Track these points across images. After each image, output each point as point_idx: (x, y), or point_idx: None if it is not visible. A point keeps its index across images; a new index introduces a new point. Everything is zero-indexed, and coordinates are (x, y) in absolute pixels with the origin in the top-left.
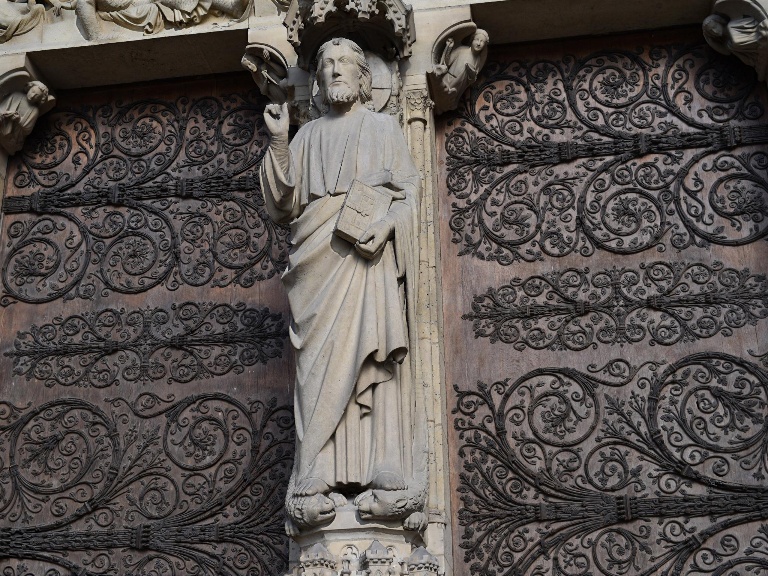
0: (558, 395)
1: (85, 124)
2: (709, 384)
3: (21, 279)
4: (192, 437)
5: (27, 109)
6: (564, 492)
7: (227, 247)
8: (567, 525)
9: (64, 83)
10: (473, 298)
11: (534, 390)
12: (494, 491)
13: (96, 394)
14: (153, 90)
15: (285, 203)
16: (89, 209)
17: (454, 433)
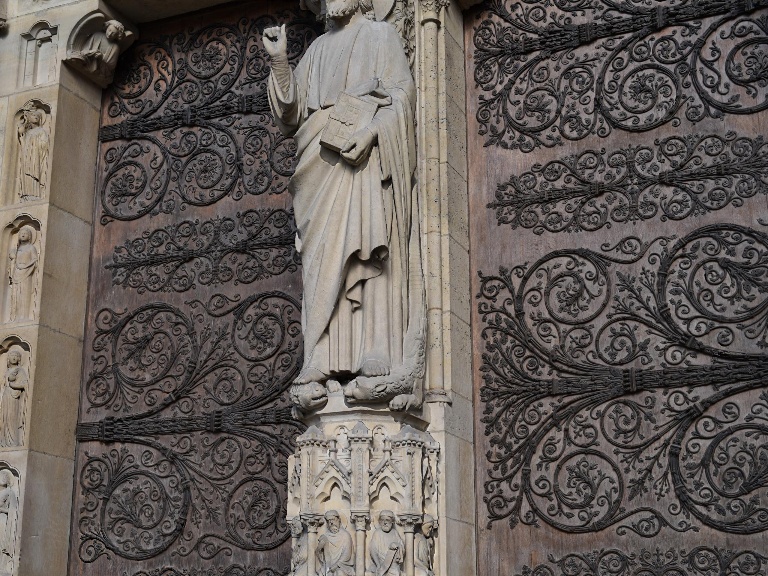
0: (572, 275)
1: (164, 53)
2: (717, 256)
3: (116, 200)
4: (254, 332)
5: (108, 46)
6: (575, 367)
7: (282, 156)
8: (577, 398)
9: (142, 17)
10: (497, 187)
11: (551, 272)
12: (512, 369)
13: (178, 298)
14: (218, 14)
15: (289, 118)
16: (168, 131)
17: (478, 317)
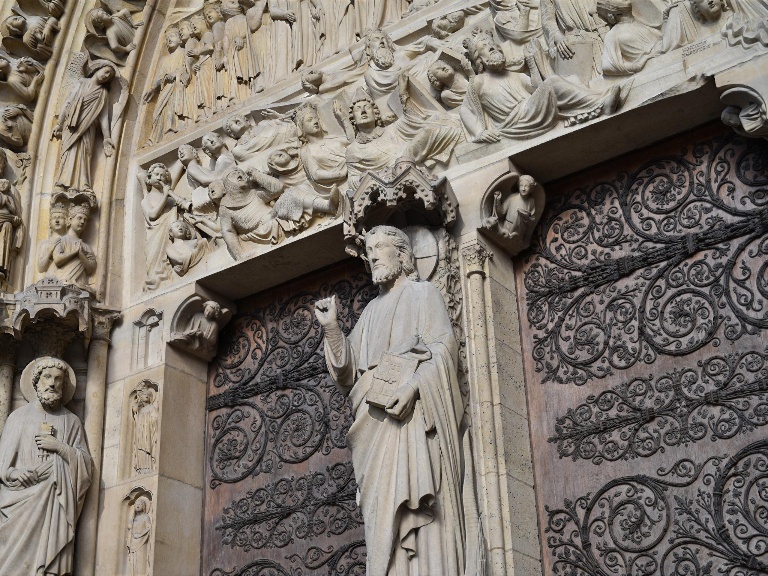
0: (633, 503)
1: (258, 324)
2: None
3: (223, 464)
4: None
5: (207, 325)
6: None
7: None
8: None
9: (237, 295)
10: (556, 421)
11: (612, 501)
12: None
13: (279, 553)
14: (303, 284)
15: (345, 380)
16: (265, 396)
17: (548, 551)
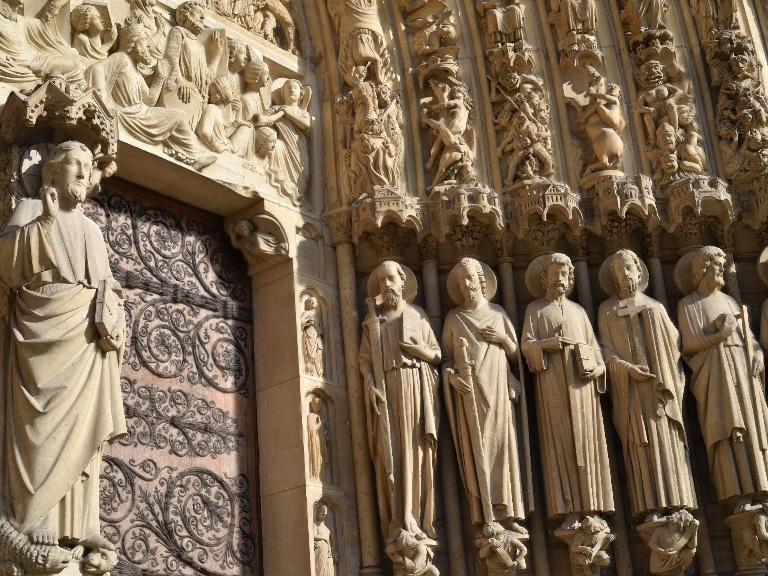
0: (110, 479)
1: None
2: (201, 492)
3: None
4: None
5: None
6: None
7: None
8: None
9: None
10: None
11: None
12: None
13: None
14: None
15: None
16: None
17: None
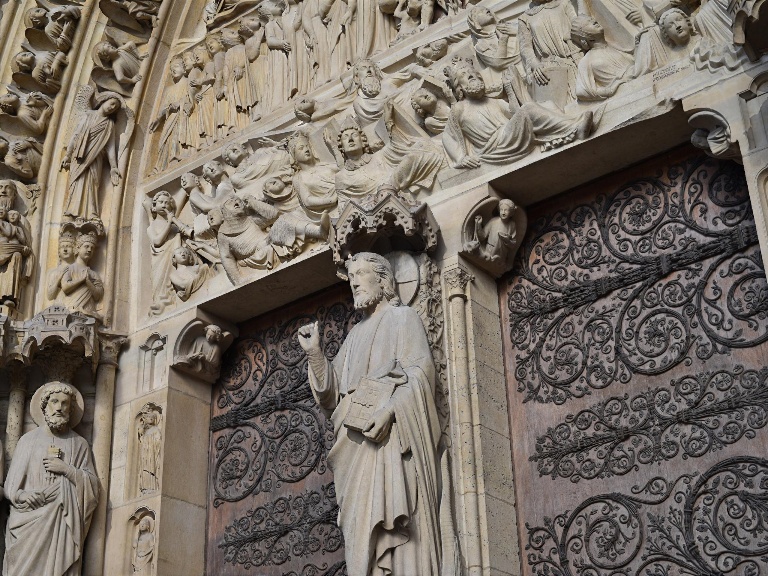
0: (608, 520)
1: (259, 346)
2: (737, 489)
3: (225, 483)
4: None
5: (209, 348)
6: None
7: None
8: None
9: (238, 318)
10: (536, 440)
11: (589, 518)
12: None
13: (277, 570)
14: (301, 307)
15: (328, 404)
16: (265, 416)
17: (528, 568)
